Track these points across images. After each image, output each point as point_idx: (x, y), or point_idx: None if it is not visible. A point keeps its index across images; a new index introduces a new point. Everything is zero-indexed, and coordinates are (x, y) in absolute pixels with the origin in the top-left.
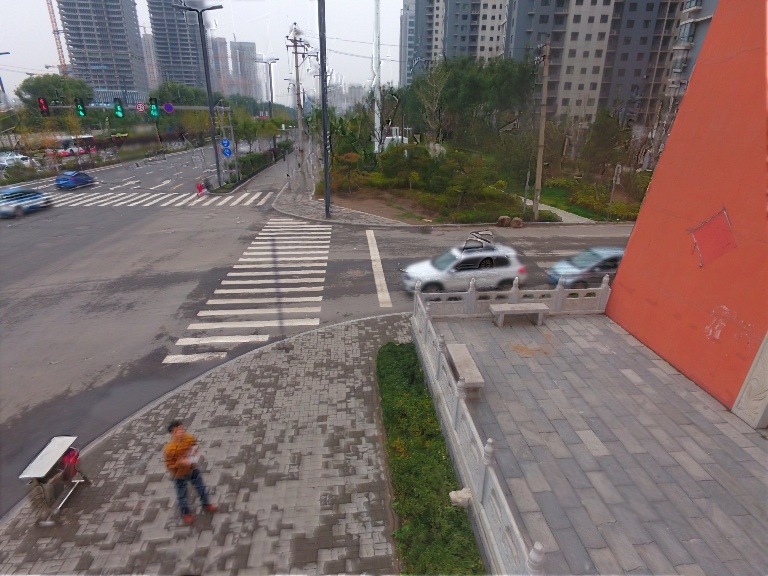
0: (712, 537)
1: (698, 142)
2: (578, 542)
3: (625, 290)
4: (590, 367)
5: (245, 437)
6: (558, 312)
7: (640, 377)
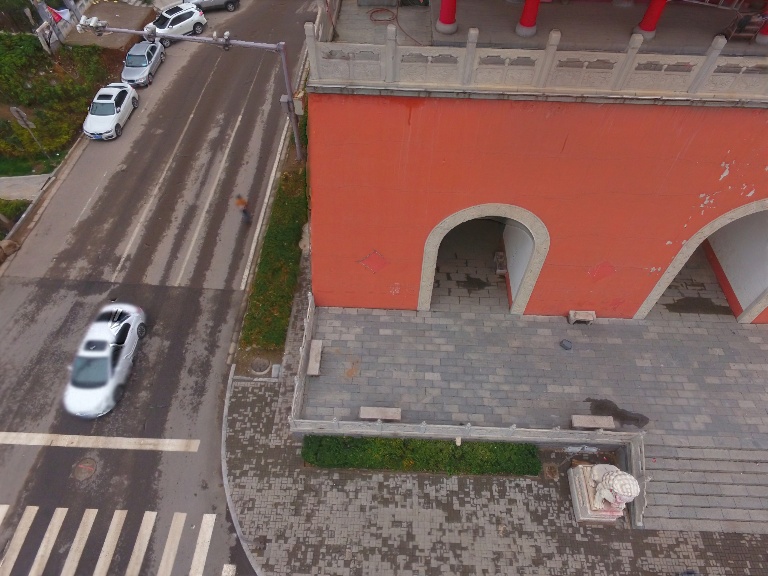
0: (479, 364)
1: (339, 225)
2: (481, 407)
3: (326, 293)
4: (375, 347)
5: (375, 560)
6: (311, 332)
7: (388, 329)
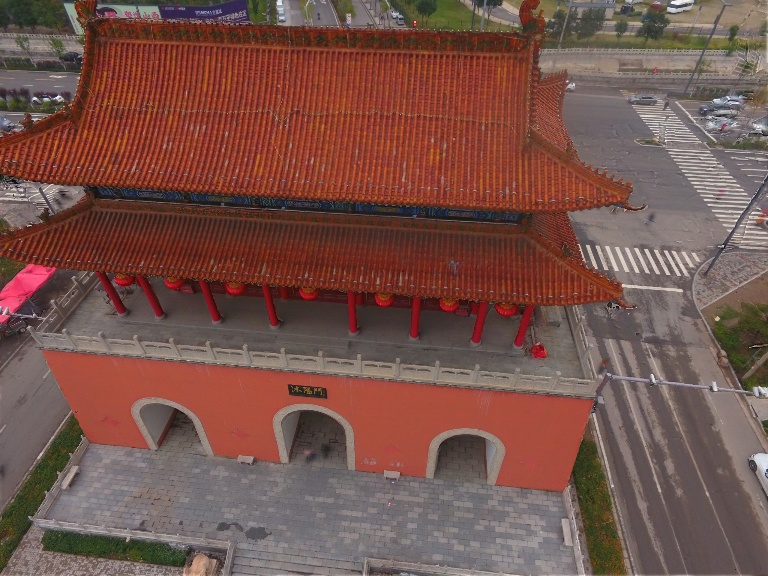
0: None
1: None
2: None
3: None
4: None
5: None
6: None
7: None
